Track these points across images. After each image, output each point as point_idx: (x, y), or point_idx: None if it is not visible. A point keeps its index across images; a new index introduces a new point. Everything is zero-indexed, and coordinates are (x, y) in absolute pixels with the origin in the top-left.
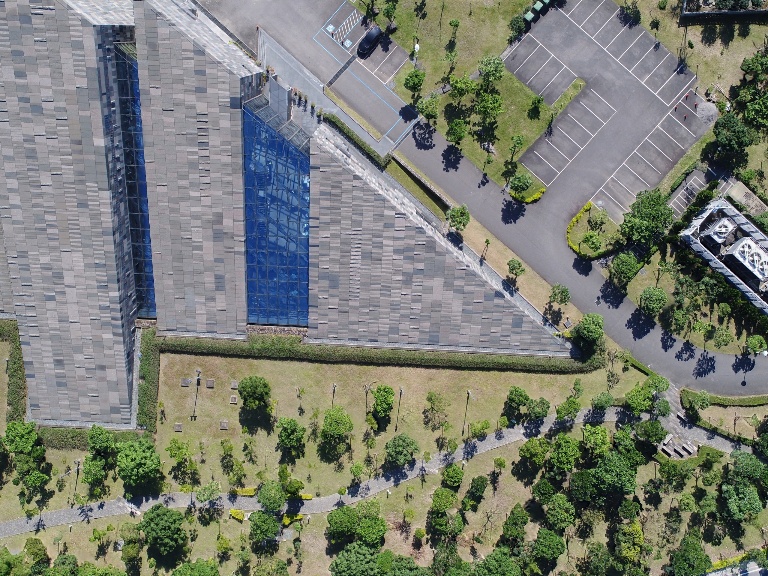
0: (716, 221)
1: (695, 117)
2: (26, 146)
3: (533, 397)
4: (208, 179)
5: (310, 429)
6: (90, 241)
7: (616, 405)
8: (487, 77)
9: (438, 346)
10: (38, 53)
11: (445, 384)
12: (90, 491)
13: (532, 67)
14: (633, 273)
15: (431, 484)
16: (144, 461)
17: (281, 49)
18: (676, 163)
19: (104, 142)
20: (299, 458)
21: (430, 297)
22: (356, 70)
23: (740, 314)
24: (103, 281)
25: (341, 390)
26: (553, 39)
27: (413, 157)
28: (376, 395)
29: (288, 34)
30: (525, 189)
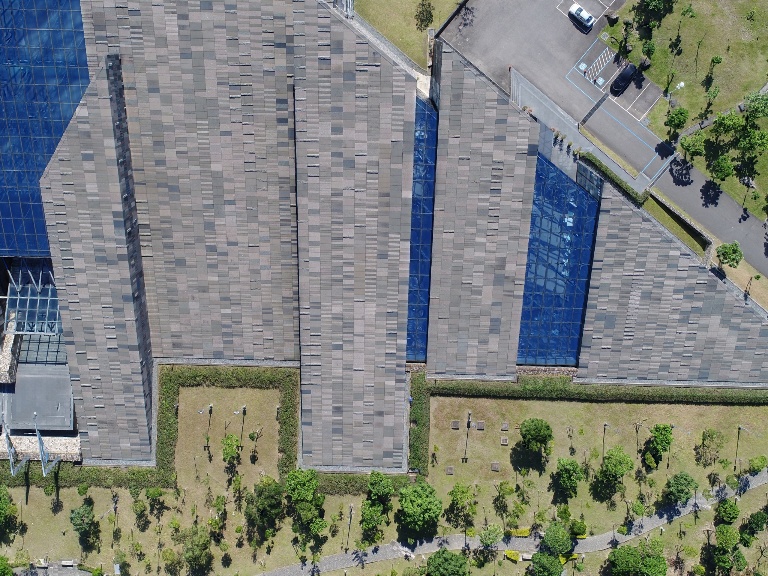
0: None
1: None
2: (333, 200)
3: None
4: (496, 225)
5: None
6: (385, 291)
7: None
8: (754, 113)
9: (707, 382)
10: (357, 109)
11: (715, 420)
12: (363, 536)
13: None
14: None
15: (704, 520)
16: (430, 506)
17: (534, 89)
18: None
19: None
20: (571, 497)
21: (705, 335)
22: (609, 108)
23: None
24: (393, 329)
25: (611, 429)
26: None
27: (671, 193)
28: (656, 434)
29: (540, 73)
30: None
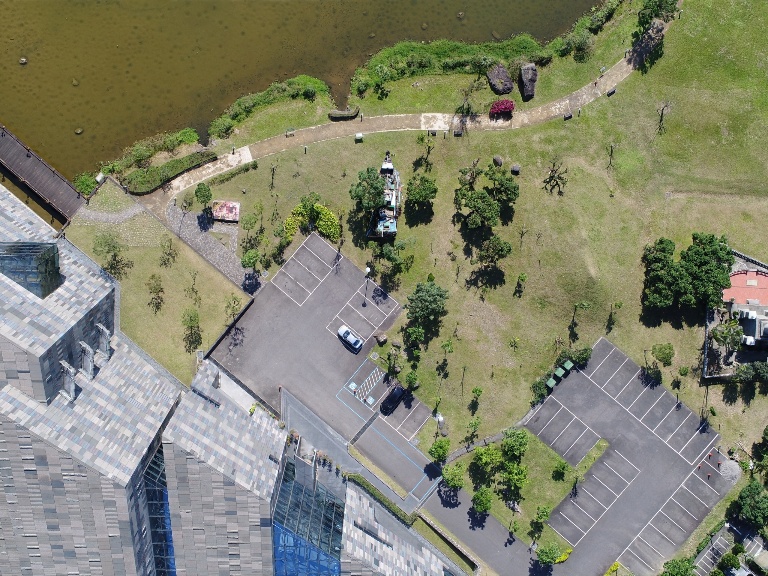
0: None
1: (719, 475)
2: None
3: None
4: None
5: None
6: None
7: None
8: (511, 448)
9: None
10: (70, 510)
11: None
12: None
13: (555, 429)
14: None
15: None
16: None
17: (304, 409)
18: (701, 521)
19: None
20: None
21: None
22: (379, 427)
23: None
24: None
25: None
26: (575, 401)
27: (439, 515)
28: None
29: (311, 393)
30: None
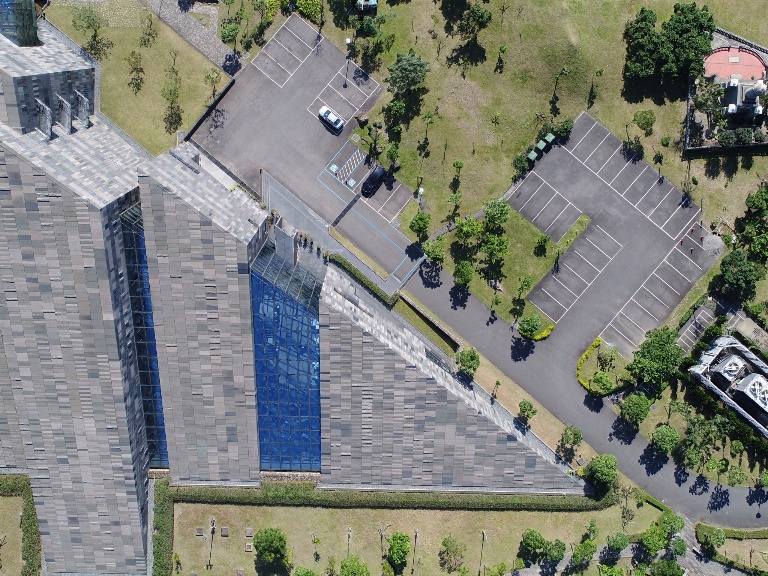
0: (726, 356)
1: (701, 250)
2: (35, 322)
3: (548, 536)
4: (218, 339)
5: (326, 574)
6: (102, 408)
7: (631, 541)
8: (492, 219)
9: (452, 487)
10: (45, 237)
11: (460, 525)
12: None
13: (537, 205)
14: (645, 414)
15: None
16: None
17: (285, 190)
18: (684, 297)
19: (113, 316)
20: None
21: (442, 442)
22: (361, 209)
23: (752, 447)
24: (116, 444)
25: (356, 534)
26: (557, 176)
27: (420, 295)
28: (392, 543)
29: (292, 175)
30: (534, 331)
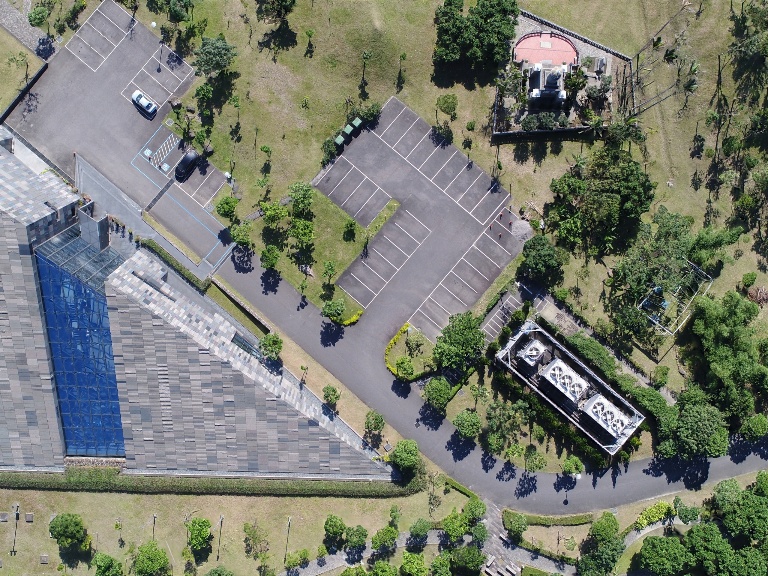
0: (530, 342)
1: (510, 235)
2: None
3: (355, 522)
4: (7, 322)
5: (131, 561)
6: None
7: (438, 528)
8: (297, 203)
9: (258, 473)
10: None
11: (266, 511)
12: None
13: (346, 189)
14: (444, 399)
15: None
16: None
17: (98, 175)
18: (492, 282)
19: None
20: None
21: (244, 427)
22: (174, 194)
23: None
24: None
25: (161, 520)
26: (366, 161)
27: (232, 280)
28: (190, 529)
29: (105, 159)
30: None
